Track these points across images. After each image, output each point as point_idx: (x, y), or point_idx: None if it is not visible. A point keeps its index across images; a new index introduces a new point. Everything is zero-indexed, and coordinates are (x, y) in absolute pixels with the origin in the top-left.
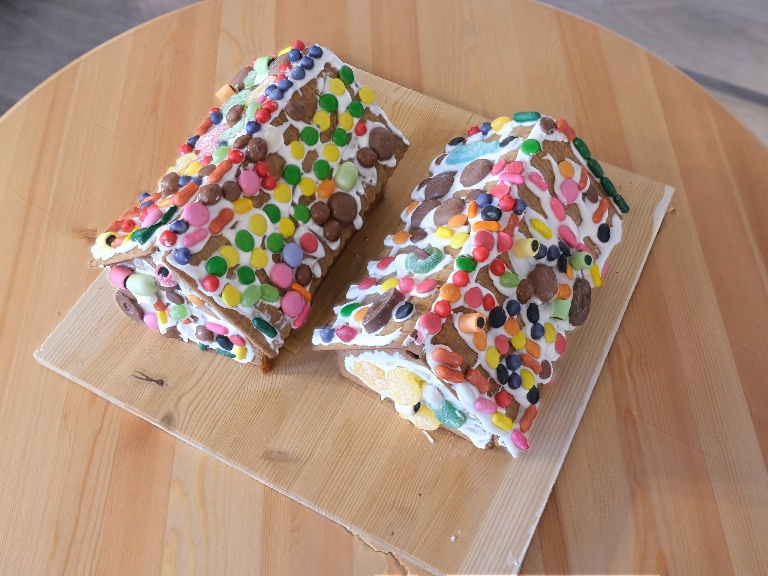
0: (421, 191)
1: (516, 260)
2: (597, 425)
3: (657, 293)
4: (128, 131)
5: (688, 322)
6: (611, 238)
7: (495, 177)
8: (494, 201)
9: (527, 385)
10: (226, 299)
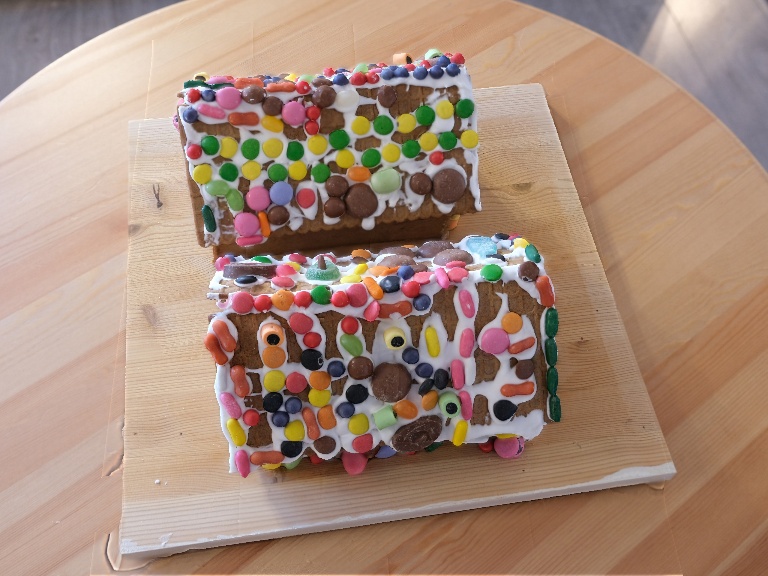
0: None
1: (381, 340)
2: (356, 548)
3: (545, 527)
4: (363, 48)
5: (536, 575)
6: (513, 423)
7: None
8: (410, 279)
9: (289, 433)
10: (196, 172)
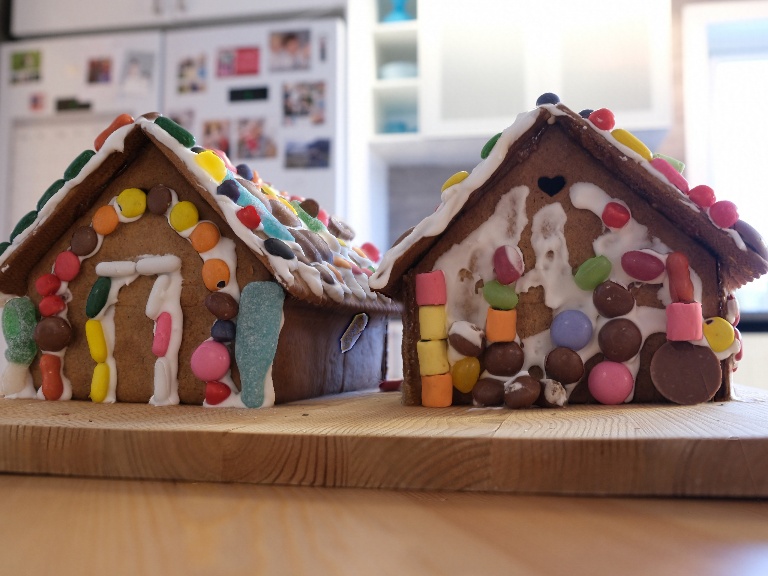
0: None
1: None
2: None
3: None
4: None
5: None
6: None
7: None
8: None
9: None
10: None
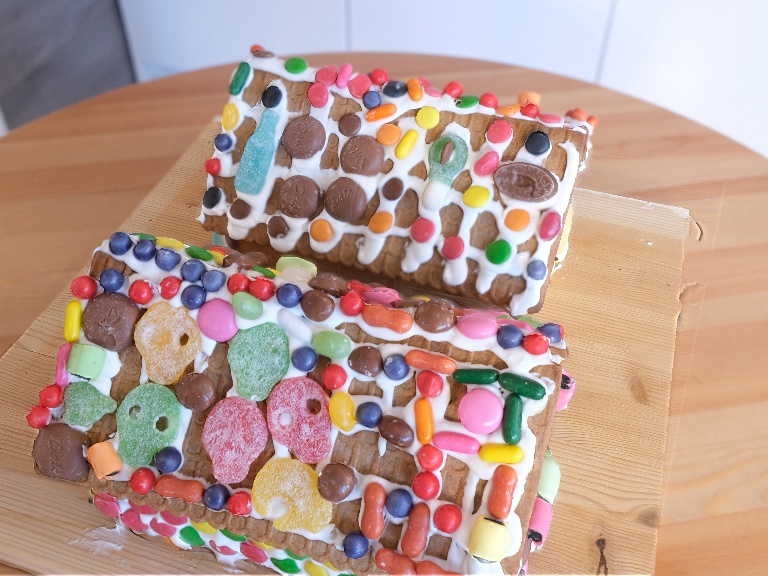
0: (296, 223)
1: None
2: None
3: None
4: None
5: None
6: None
7: (330, 101)
8: None
9: None
10: None
